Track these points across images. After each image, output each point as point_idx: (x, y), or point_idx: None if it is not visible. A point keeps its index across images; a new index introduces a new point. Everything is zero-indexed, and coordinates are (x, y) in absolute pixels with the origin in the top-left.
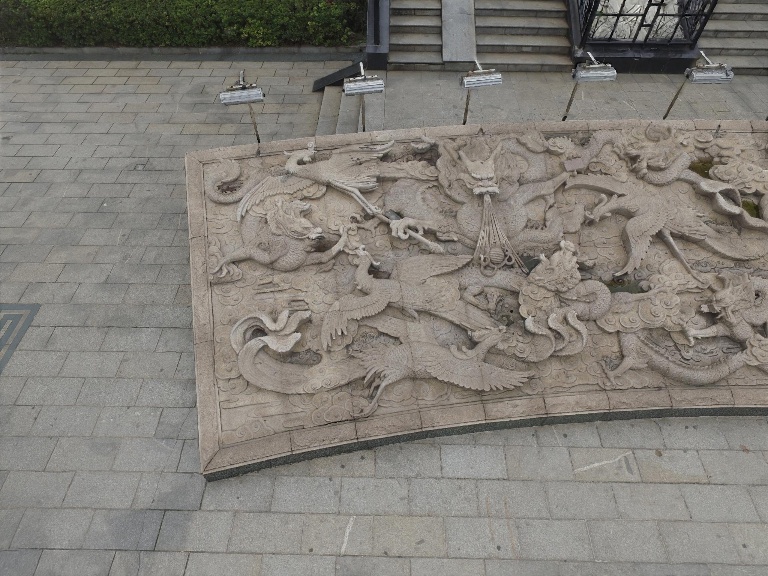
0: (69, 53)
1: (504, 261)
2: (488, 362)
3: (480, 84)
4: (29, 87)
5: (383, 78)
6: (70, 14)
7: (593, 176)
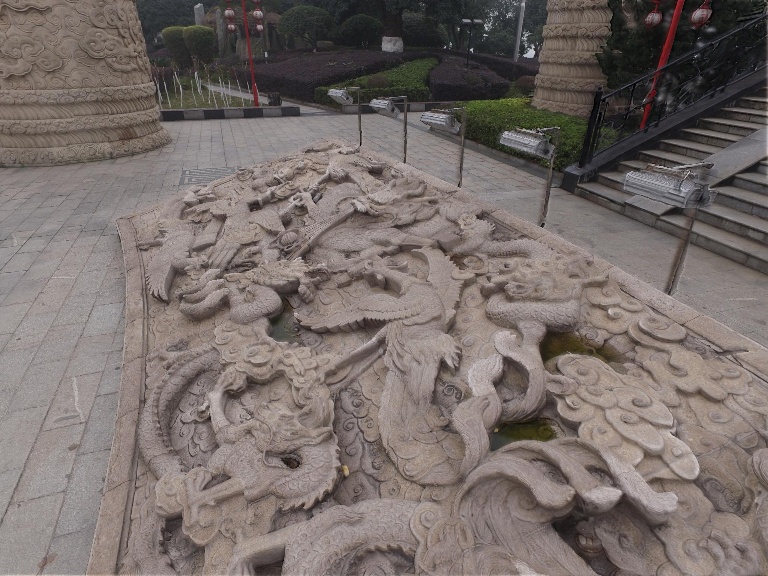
0: (460, 141)
1: (286, 246)
2: (182, 279)
3: (431, 120)
4: (416, 142)
5: (556, 194)
6: (469, 116)
7: (446, 258)
